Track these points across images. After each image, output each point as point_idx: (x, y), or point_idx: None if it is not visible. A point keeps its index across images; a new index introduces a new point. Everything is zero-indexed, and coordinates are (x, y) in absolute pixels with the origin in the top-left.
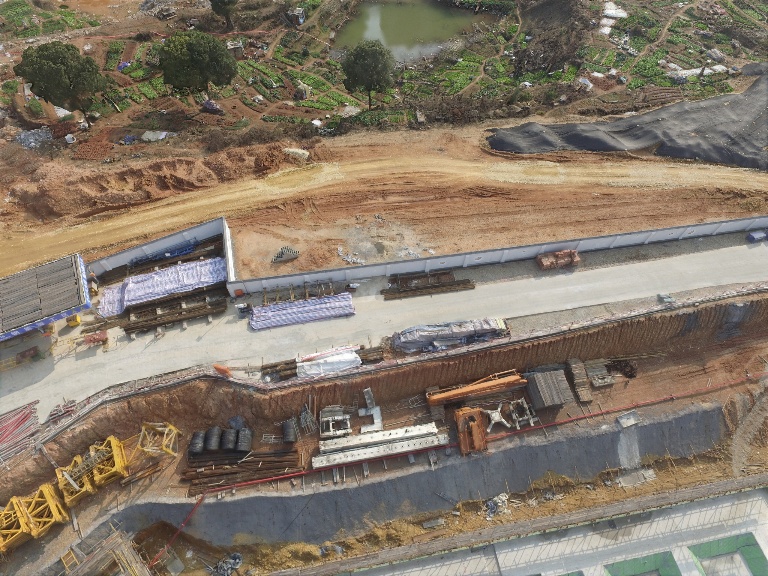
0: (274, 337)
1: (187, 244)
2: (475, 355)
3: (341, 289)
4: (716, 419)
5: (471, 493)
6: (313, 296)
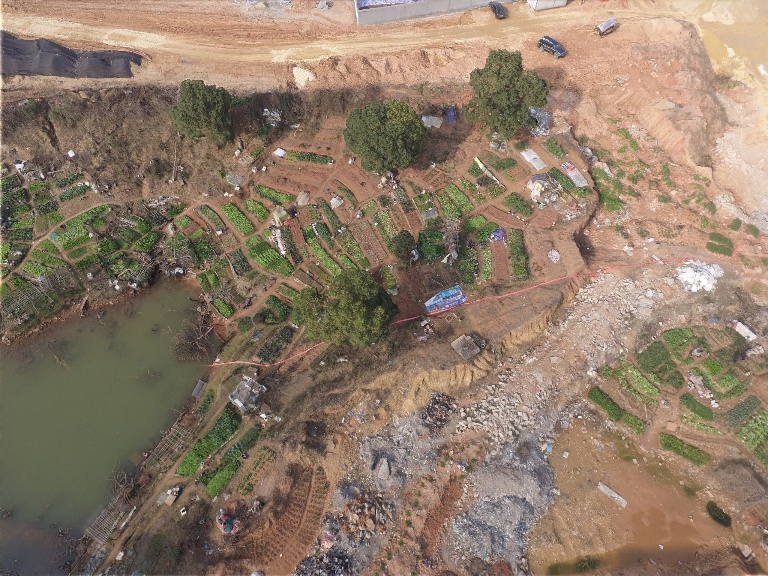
0: None
1: None
2: None
3: None
4: None
5: None
6: None
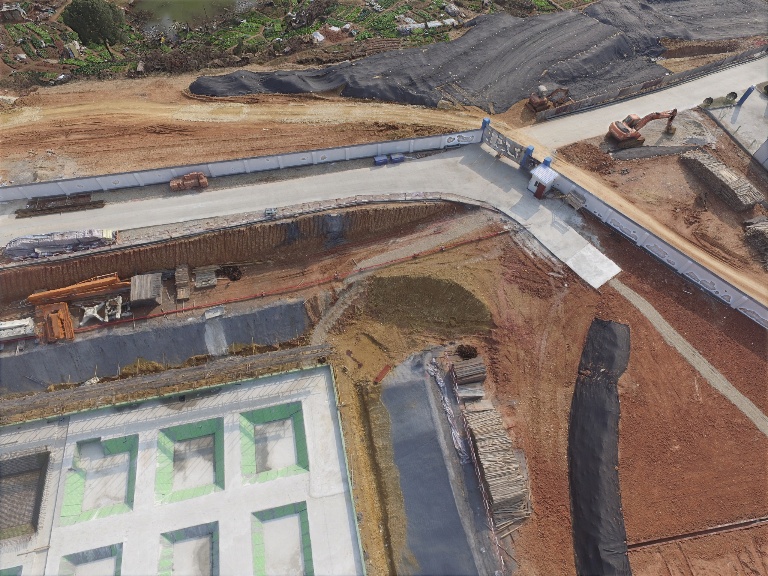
0: None
1: None
2: (77, 260)
3: None
4: (300, 312)
5: (63, 377)
6: None
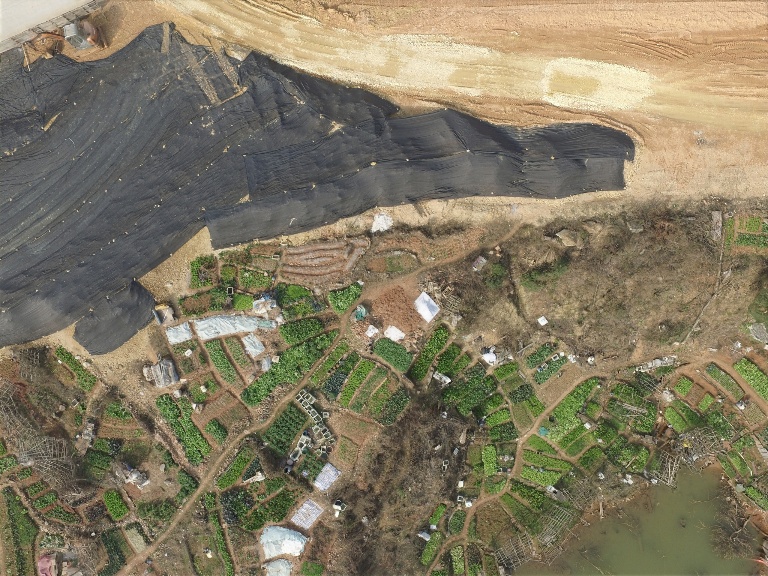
0: None
1: None
2: None
3: None
4: None
5: None
6: None
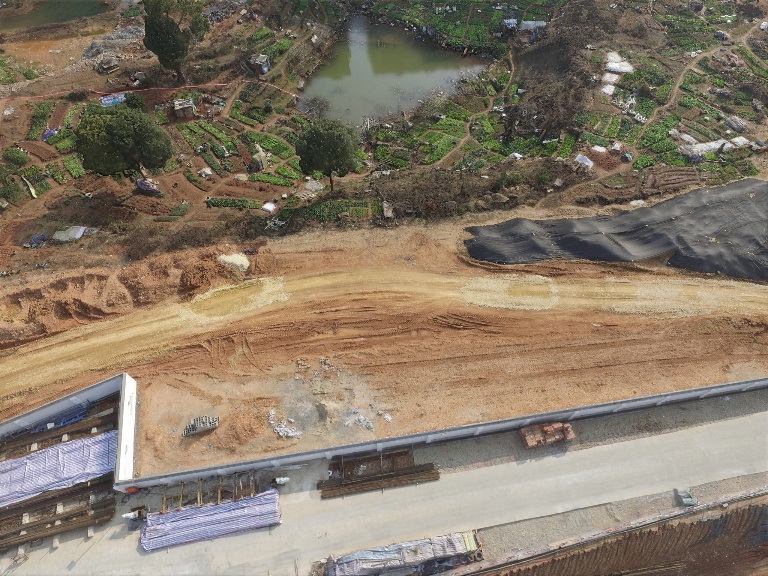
0: (171, 563)
1: (78, 407)
2: None
3: (267, 481)
4: None
5: None
6: (229, 493)
